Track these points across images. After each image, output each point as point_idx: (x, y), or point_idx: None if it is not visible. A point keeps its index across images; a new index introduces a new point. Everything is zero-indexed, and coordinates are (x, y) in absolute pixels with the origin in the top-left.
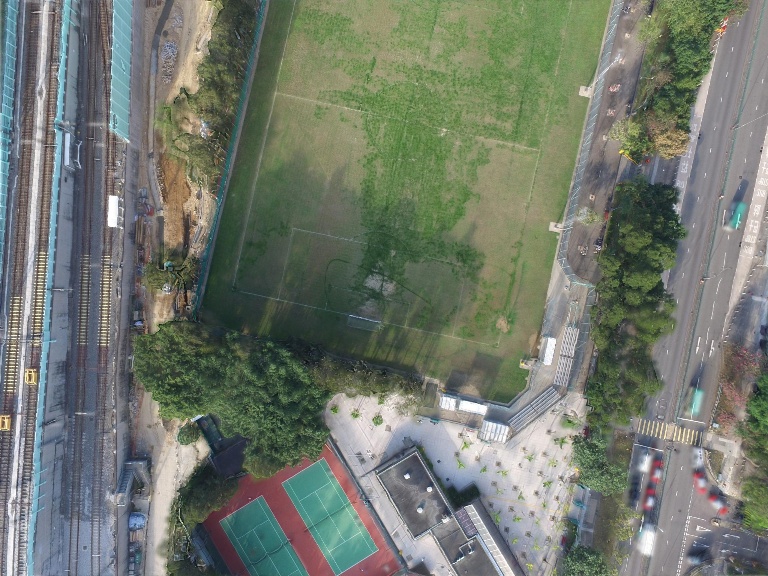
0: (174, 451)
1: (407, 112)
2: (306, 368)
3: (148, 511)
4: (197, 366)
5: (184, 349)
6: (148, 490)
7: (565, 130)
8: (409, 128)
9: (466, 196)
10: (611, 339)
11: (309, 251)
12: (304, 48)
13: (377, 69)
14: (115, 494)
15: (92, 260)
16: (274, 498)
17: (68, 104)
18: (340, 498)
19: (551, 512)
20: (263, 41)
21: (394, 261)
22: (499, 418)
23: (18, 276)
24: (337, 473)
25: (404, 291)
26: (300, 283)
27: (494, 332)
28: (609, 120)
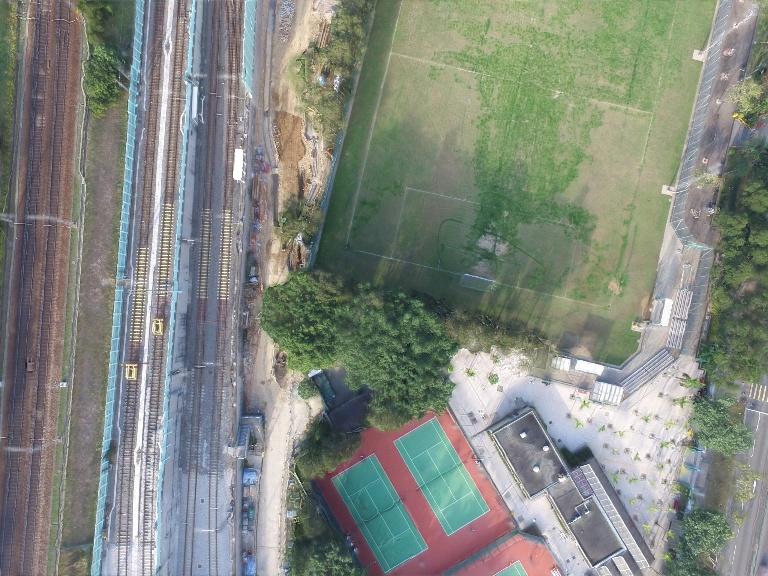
0: (288, 407)
1: (521, 74)
2: (439, 319)
3: (261, 467)
4: (331, 315)
5: (318, 298)
6: (261, 446)
7: (678, 94)
8: (523, 90)
9: (579, 158)
10: (735, 298)
11: (422, 211)
12: (419, 9)
13: (491, 31)
14: (235, 447)
15: (213, 214)
16: (386, 456)
17: (195, 58)
18: (451, 457)
19: (663, 475)
20: (379, 2)
21: (507, 222)
22: (611, 380)
23: (144, 227)
24: (449, 432)
25: (517, 252)
26: (413, 242)
27: (606, 294)
28: (723, 84)
